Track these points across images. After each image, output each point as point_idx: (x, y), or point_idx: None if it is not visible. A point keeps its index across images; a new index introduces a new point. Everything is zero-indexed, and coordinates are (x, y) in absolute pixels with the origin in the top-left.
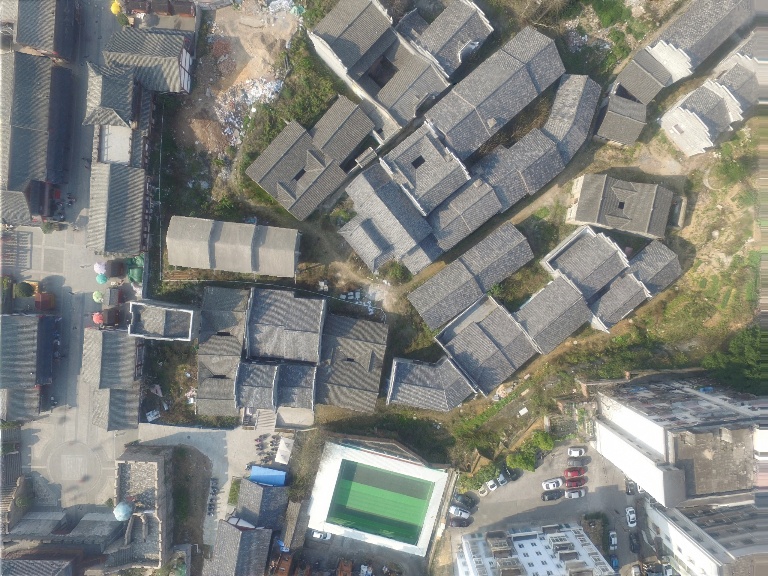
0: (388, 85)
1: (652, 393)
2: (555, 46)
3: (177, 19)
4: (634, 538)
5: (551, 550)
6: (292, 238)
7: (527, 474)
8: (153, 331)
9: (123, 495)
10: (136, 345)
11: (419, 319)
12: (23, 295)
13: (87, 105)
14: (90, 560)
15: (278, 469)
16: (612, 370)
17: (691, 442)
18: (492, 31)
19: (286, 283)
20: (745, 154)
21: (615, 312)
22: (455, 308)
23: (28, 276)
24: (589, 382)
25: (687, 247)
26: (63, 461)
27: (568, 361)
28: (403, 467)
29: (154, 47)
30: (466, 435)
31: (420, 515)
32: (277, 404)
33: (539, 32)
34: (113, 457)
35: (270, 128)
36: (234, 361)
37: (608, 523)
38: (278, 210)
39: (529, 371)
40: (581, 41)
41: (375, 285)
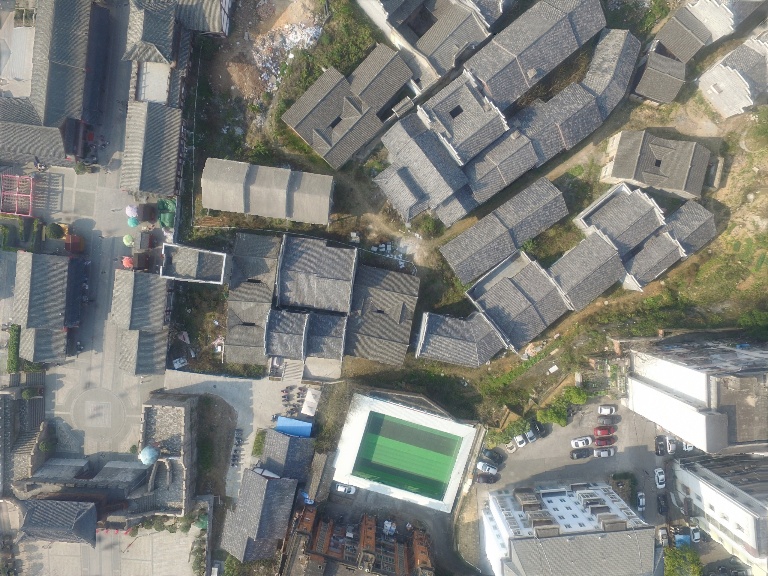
0: (428, 34)
1: (687, 350)
2: None
3: None
4: (662, 500)
5: (581, 505)
6: (327, 184)
7: (556, 432)
8: (185, 273)
9: (148, 441)
10: (167, 288)
11: (450, 274)
12: (54, 236)
13: (127, 40)
14: (114, 505)
15: (304, 420)
16: (645, 328)
17: (735, 386)
18: None
19: (317, 234)
20: None
21: (649, 270)
22: (488, 262)
23: (58, 218)
24: (622, 339)
25: (721, 209)
26: (87, 407)
27: (598, 321)
28: (431, 421)
29: None
30: (494, 393)
31: (446, 472)
32: (306, 354)
33: None
34: (138, 404)
35: (307, 75)
36: (264, 308)
37: (637, 484)
38: (312, 159)
39: (559, 330)
40: None
41: (407, 238)
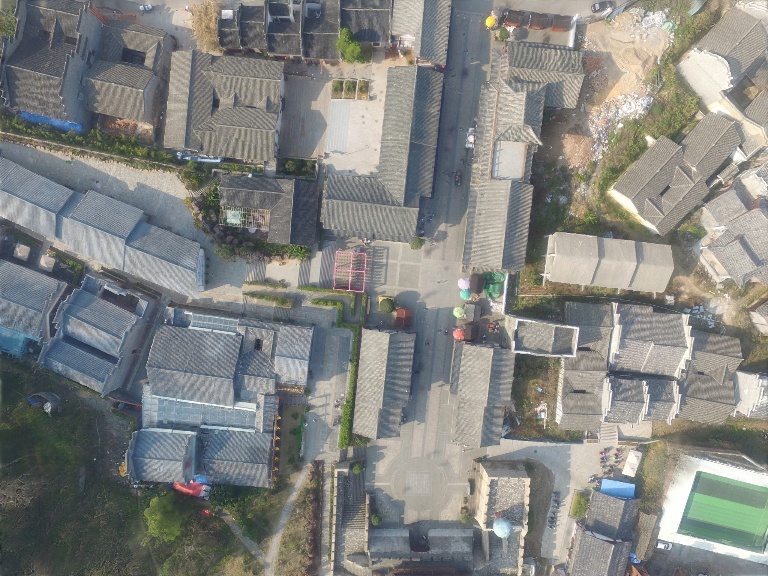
0: (756, 102)
1: None
2: None
3: (547, 33)
4: None
5: None
6: (668, 254)
7: None
8: (536, 348)
9: (488, 511)
10: None
11: (757, 332)
12: (390, 311)
13: (498, 121)
14: None
15: (627, 482)
16: None
17: None
18: None
19: (631, 297)
20: None
21: None
22: None
23: (382, 292)
24: None
25: None
26: (408, 477)
27: None
28: (755, 478)
29: (556, 63)
30: None
31: (757, 524)
32: None
33: None
34: (459, 473)
35: (633, 143)
36: (599, 376)
37: None
38: (631, 225)
39: None
40: None
41: (717, 299)
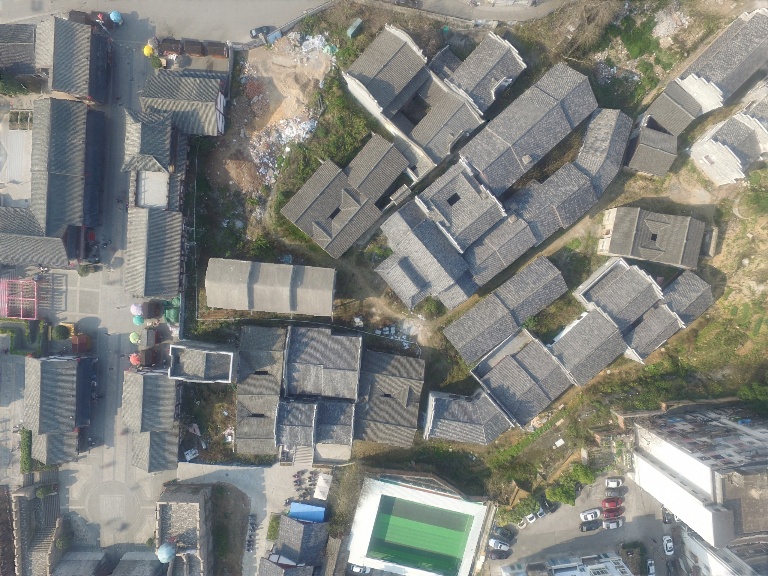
0: (422, 123)
1: (690, 425)
2: (588, 82)
3: (209, 60)
4: (671, 566)
5: None
6: (330, 278)
7: (565, 505)
8: (193, 373)
9: (164, 535)
10: None
11: (454, 352)
12: (60, 338)
13: (125, 151)
14: None
15: (317, 505)
16: (648, 401)
17: (739, 483)
18: (525, 68)
19: (321, 319)
20: None
21: (649, 343)
22: (491, 342)
23: (63, 318)
24: (626, 414)
25: (718, 275)
26: (101, 501)
27: (602, 390)
28: (442, 501)
29: (190, 91)
30: (502, 466)
31: (458, 547)
32: (316, 441)
33: (572, 68)
34: (152, 496)
35: (304, 167)
36: (273, 400)
37: (646, 552)
38: (313, 247)
39: (563, 401)
40: (610, 73)
41: (410, 320)
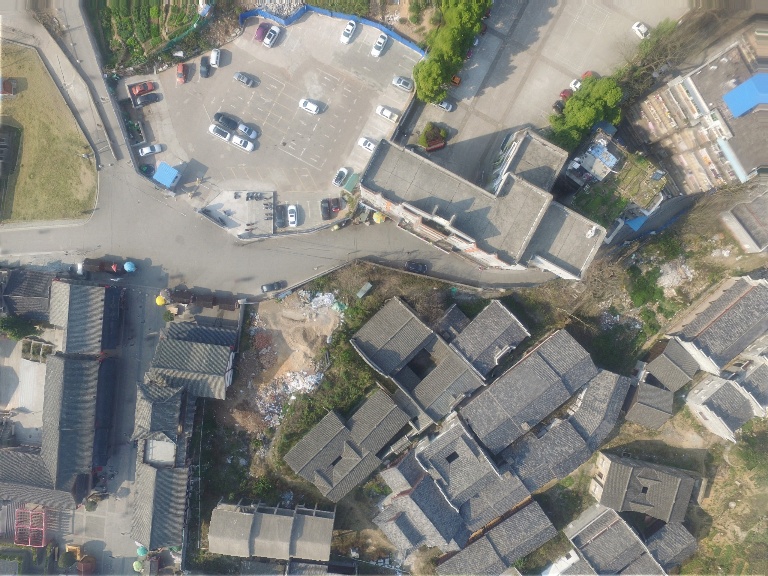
0: (425, 382)
1: None
2: (590, 357)
3: None
4: None
5: None
6: (328, 529)
7: None
8: None
9: None
10: None
11: None
12: (66, 567)
13: (135, 422)
14: None
15: None
16: None
17: None
18: (529, 336)
19: None
20: (765, 430)
21: None
22: None
23: (70, 540)
24: None
25: (704, 516)
26: None
27: None
28: None
29: (201, 360)
30: None
31: None
32: None
33: (575, 340)
34: None
35: (309, 413)
36: None
37: None
38: (313, 484)
39: None
40: (613, 320)
41: None
